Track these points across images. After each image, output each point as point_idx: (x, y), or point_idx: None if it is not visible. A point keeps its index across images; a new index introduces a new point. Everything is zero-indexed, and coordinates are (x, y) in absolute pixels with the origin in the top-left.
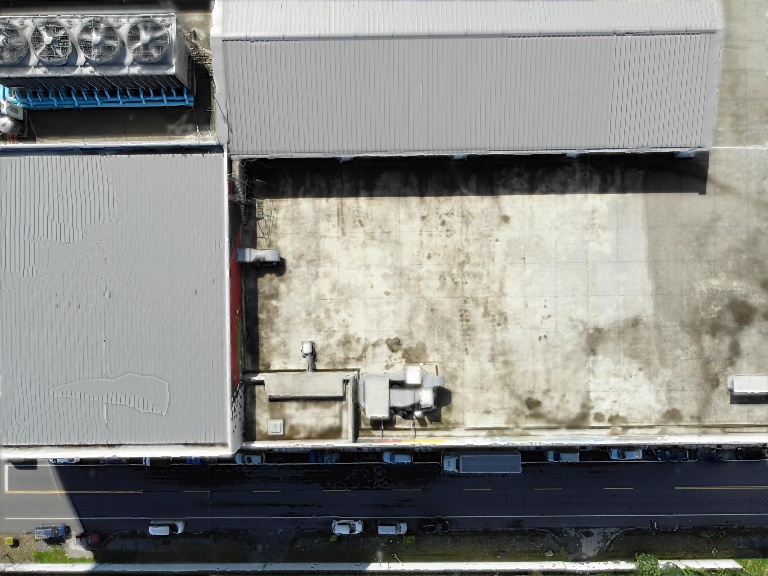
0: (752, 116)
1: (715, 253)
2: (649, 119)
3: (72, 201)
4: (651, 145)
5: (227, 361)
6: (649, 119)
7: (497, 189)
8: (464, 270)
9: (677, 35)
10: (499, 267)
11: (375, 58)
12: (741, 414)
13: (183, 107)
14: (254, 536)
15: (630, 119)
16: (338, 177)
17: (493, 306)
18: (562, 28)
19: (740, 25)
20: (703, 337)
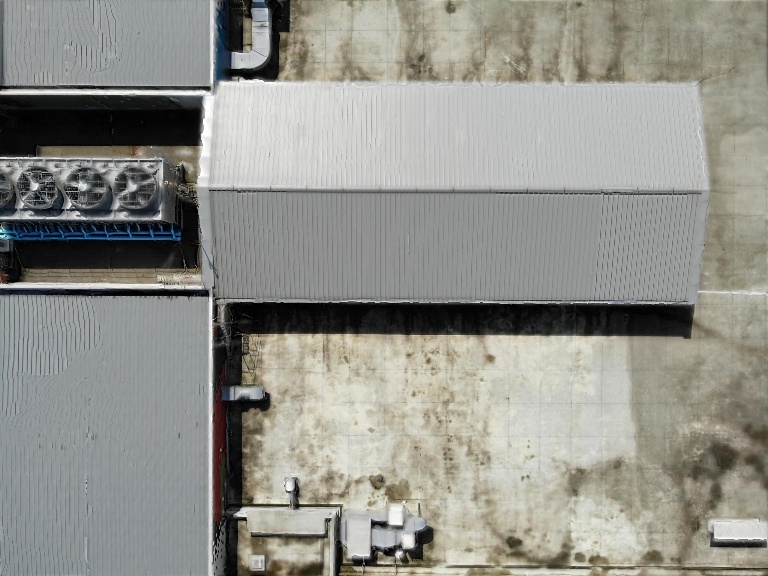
0: (738, 260)
1: (699, 396)
2: (635, 273)
3: (57, 330)
4: (636, 298)
5: (209, 506)
6: (635, 273)
7: (483, 329)
8: (448, 408)
9: (664, 194)
10: (483, 406)
11: (362, 210)
12: (721, 556)
13: (170, 241)
14: None
15: (616, 273)
16: (324, 313)
17: (477, 445)
18: (549, 185)
19: (729, 169)
20: (685, 480)
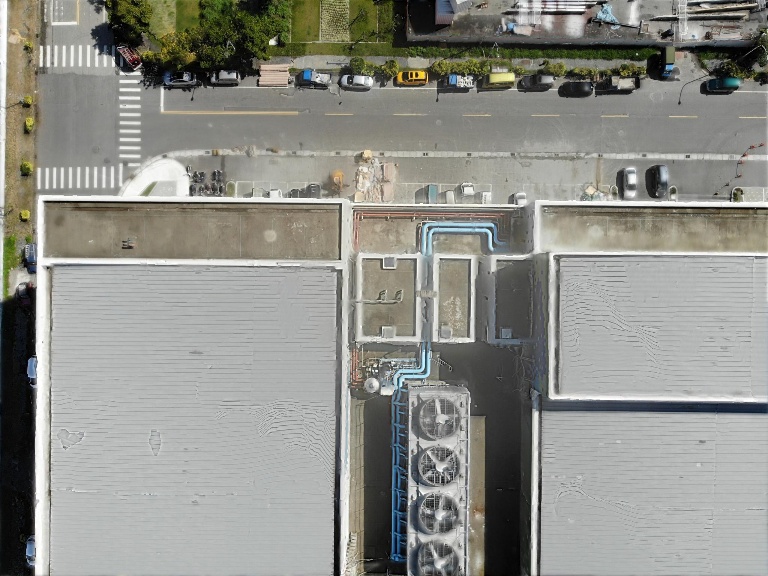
0: None
1: None
2: None
3: None
4: None
5: None
6: None
7: None
8: None
9: None
10: None
11: None
12: None
13: None
14: (28, 456)
15: None
16: None
17: None
18: None
19: None
20: None
